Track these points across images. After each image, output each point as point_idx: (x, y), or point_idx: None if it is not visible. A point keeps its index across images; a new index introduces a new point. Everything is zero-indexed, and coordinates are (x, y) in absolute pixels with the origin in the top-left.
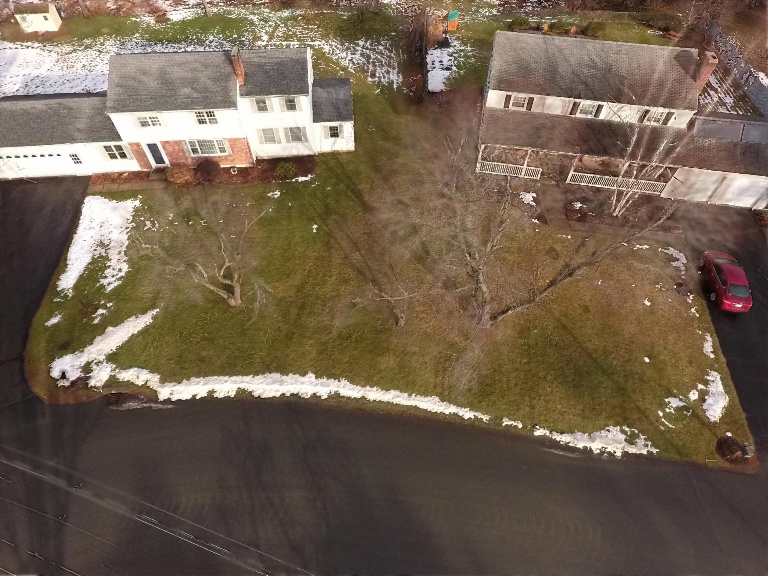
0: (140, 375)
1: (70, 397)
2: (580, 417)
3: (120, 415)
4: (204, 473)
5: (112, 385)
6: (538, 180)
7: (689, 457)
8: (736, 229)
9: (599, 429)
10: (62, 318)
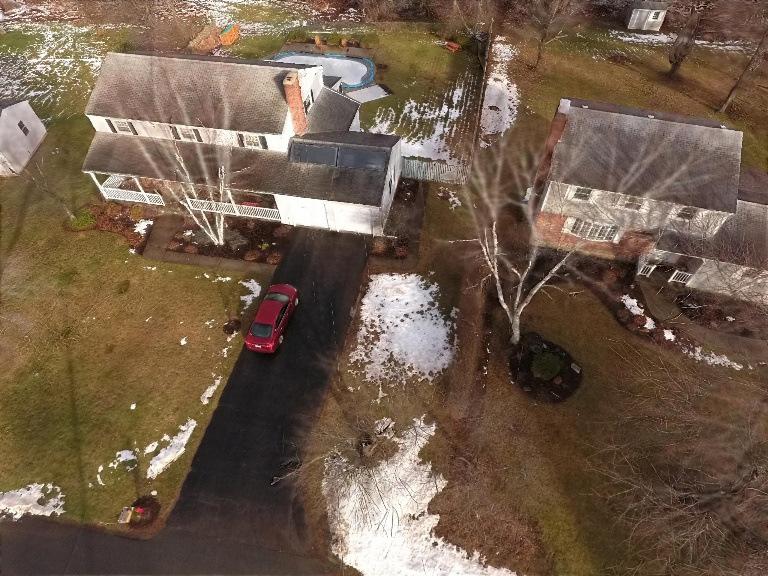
0: None
1: None
2: (8, 473)
3: None
4: None
5: None
6: (160, 207)
7: (90, 520)
8: (340, 258)
9: (19, 487)
10: None
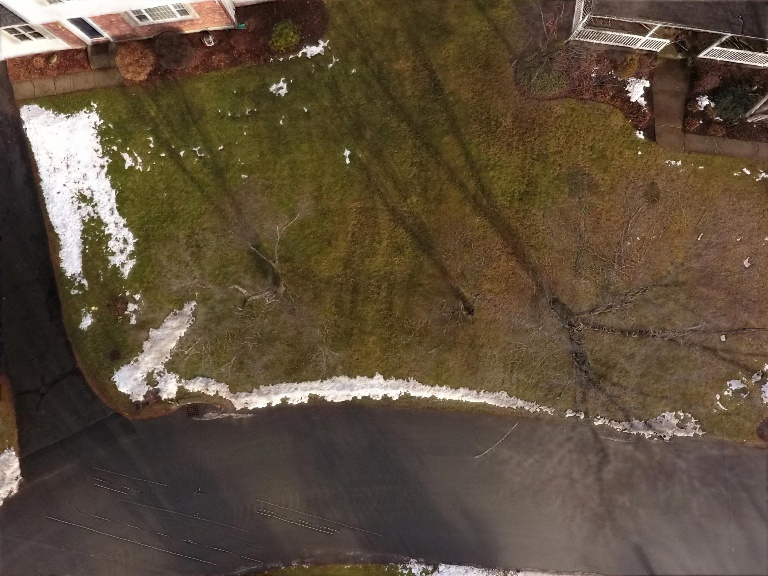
0: (209, 388)
1: (150, 412)
2: (641, 406)
3: (206, 426)
4: (301, 475)
5: (185, 397)
6: (659, 56)
7: (730, 438)
8: None
9: (656, 416)
10: (94, 318)
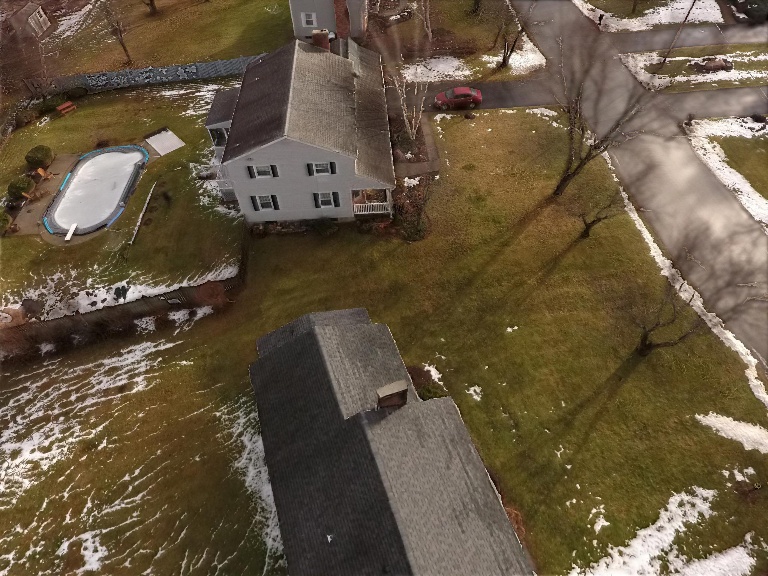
0: (759, 383)
1: None
2: None
3: None
4: None
5: None
6: None
7: (584, 121)
8: None
9: None
10: None
